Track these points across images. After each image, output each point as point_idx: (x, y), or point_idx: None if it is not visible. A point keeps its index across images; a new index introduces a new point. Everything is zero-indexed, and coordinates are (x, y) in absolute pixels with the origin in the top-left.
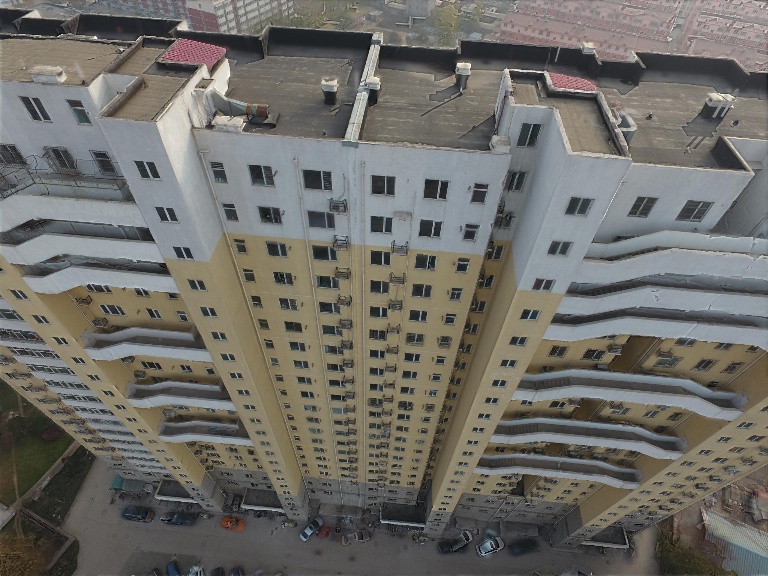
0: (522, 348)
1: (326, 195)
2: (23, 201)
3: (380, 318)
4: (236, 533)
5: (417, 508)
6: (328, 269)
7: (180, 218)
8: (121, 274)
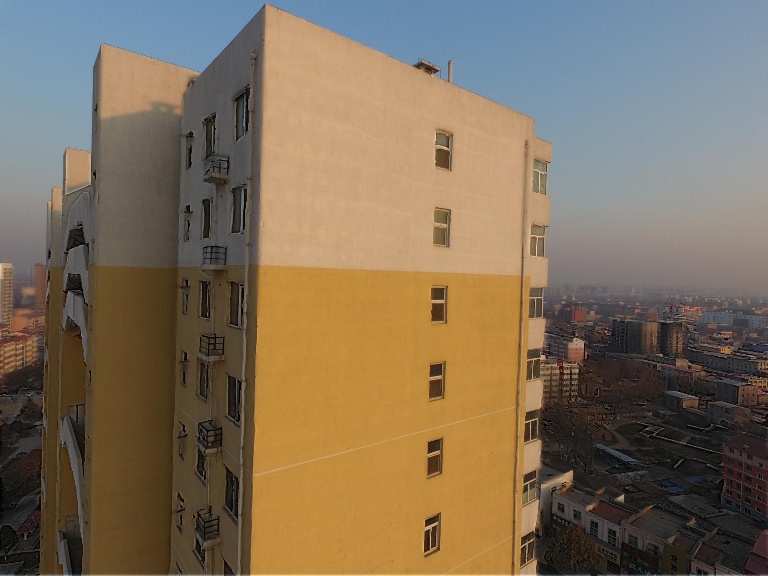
0: None
1: None
2: None
3: None
4: None
5: None
6: None
7: None
8: None
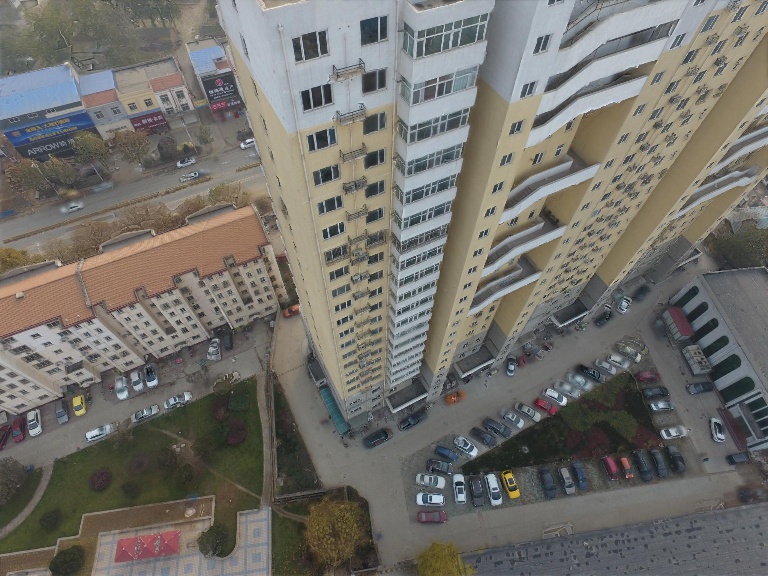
0: None
1: None
2: (614, 22)
3: (696, 84)
4: (462, 402)
5: (575, 305)
6: (702, 41)
7: None
8: (613, 89)
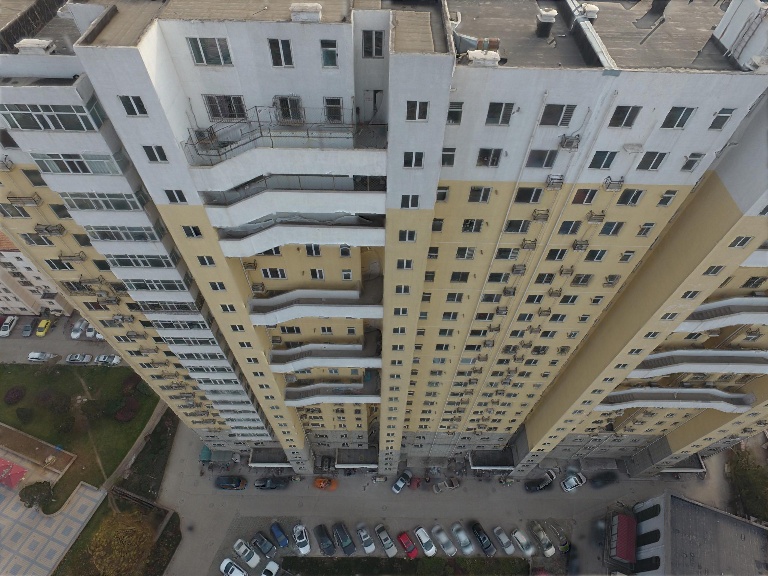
0: (713, 277)
1: (560, 131)
2: (261, 155)
3: (555, 261)
4: (330, 492)
5: (504, 453)
6: (525, 212)
7: (427, 162)
8: (330, 230)
